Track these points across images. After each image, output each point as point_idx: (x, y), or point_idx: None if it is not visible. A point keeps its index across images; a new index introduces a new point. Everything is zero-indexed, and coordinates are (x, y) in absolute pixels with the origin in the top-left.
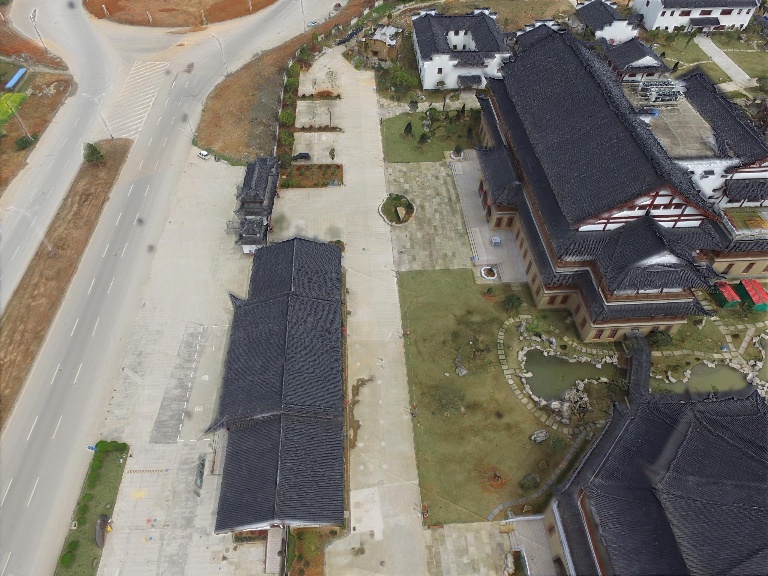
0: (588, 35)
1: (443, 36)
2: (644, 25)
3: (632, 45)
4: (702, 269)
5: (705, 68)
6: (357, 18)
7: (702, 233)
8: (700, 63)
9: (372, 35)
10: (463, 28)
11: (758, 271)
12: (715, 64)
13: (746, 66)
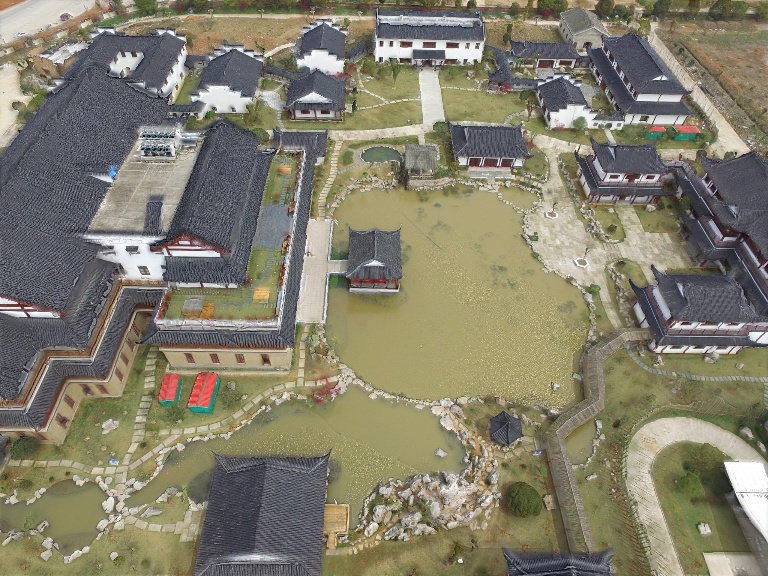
0: (292, 63)
1: (108, 57)
2: (374, 54)
3: (311, 78)
4: (87, 366)
5: (404, 107)
6: (67, 31)
7: (63, 326)
8: (403, 101)
9: (53, 51)
10: (140, 49)
11: (231, 362)
12: (419, 103)
13: (451, 107)
